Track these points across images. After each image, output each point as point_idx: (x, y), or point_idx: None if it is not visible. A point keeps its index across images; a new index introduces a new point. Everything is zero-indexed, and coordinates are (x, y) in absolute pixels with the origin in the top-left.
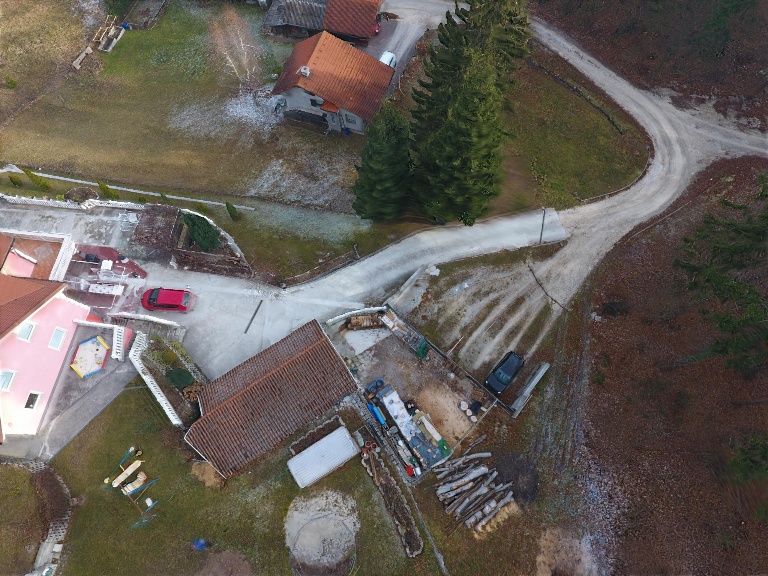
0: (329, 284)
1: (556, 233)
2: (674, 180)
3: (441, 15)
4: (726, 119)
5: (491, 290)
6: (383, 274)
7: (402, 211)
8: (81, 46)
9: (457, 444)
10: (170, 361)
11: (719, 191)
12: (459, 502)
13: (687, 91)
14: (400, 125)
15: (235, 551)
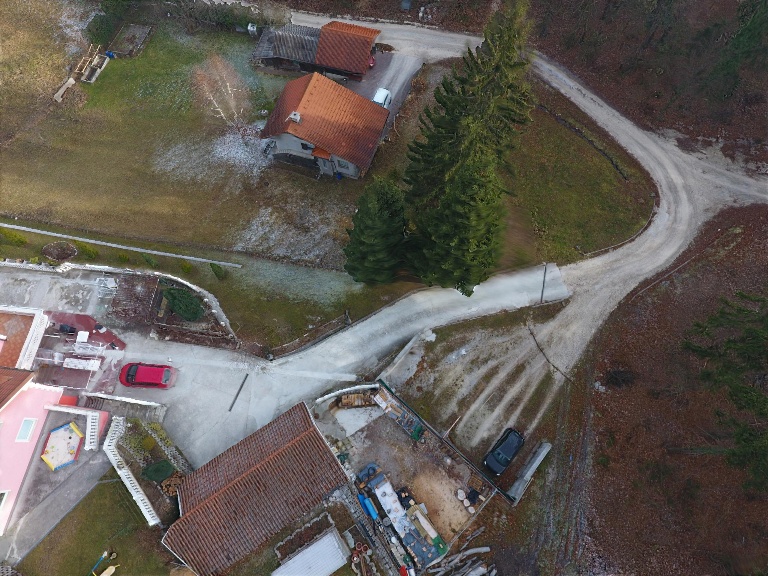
0: (319, 354)
1: (558, 291)
2: (680, 231)
3: (438, 47)
4: (734, 164)
5: (490, 357)
6: (376, 340)
7: (396, 272)
8: (63, 76)
9: (454, 539)
10: (148, 448)
11: (727, 244)
12: None
13: (693, 133)
14: (393, 198)
15: None
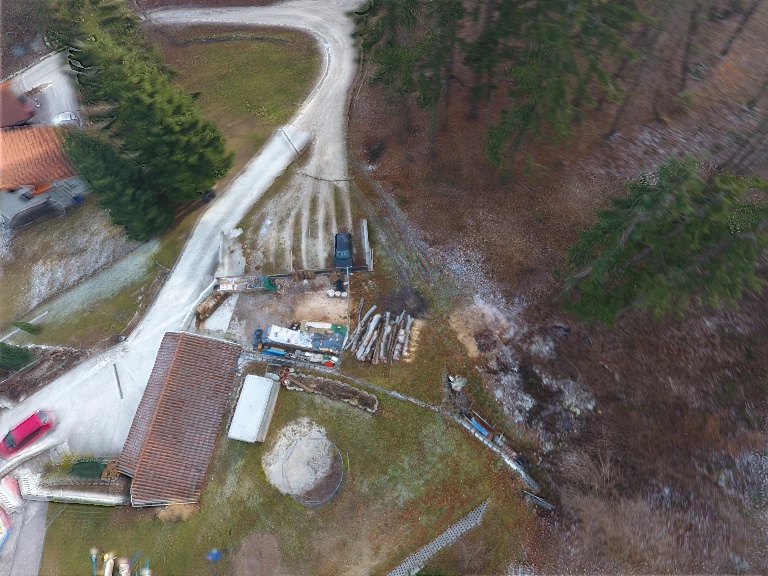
0: (161, 307)
1: (303, 139)
2: (352, 46)
3: None
4: None
5: (290, 210)
6: (200, 265)
7: (173, 210)
8: None
9: (348, 320)
10: None
11: None
12: (378, 350)
13: None
14: (94, 134)
15: (250, 538)
